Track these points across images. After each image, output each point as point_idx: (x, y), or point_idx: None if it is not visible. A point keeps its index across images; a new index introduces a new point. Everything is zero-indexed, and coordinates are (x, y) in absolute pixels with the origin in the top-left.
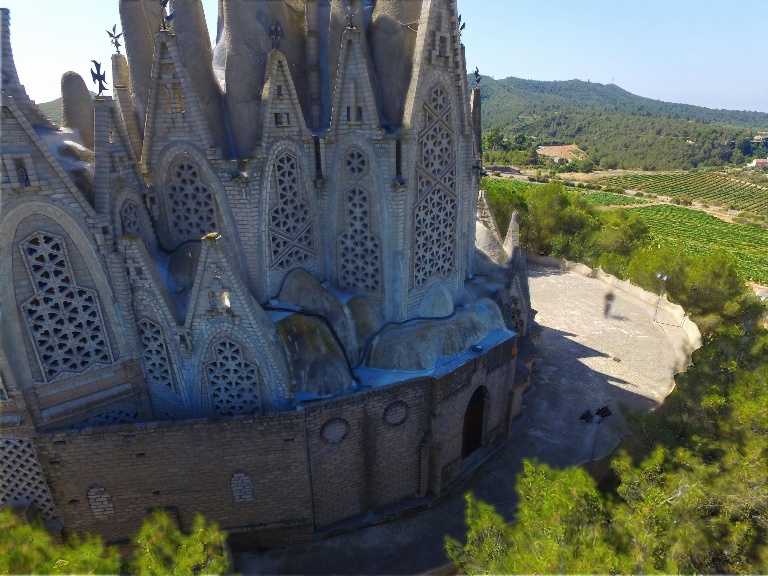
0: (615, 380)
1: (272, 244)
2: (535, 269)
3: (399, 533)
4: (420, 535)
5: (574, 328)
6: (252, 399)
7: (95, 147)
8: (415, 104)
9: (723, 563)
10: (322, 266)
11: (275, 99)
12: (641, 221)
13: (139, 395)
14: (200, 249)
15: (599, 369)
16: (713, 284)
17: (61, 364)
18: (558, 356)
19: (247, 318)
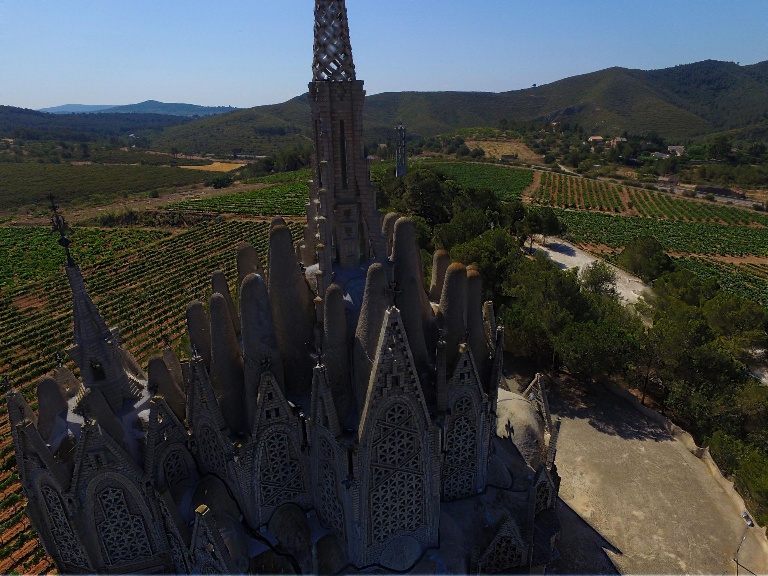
0: None
1: (263, 492)
2: (632, 422)
3: None
4: None
5: (623, 540)
6: None
7: (148, 430)
8: (365, 428)
9: None
10: (311, 498)
11: (266, 402)
12: None
13: (170, 572)
14: (214, 487)
15: None
16: None
17: (120, 555)
18: None
19: None
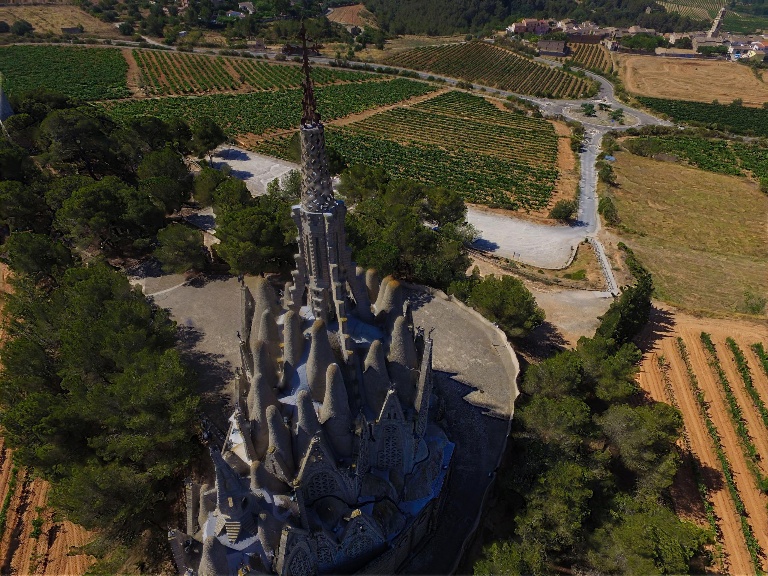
0: (485, 410)
1: None
2: (411, 298)
3: (426, 556)
4: (435, 553)
5: (454, 367)
6: (367, 548)
7: (298, 505)
8: None
9: (549, 541)
10: (369, 463)
11: None
12: (458, 196)
13: None
14: (331, 502)
15: (475, 403)
16: (518, 312)
17: None
18: (453, 399)
19: (370, 528)
